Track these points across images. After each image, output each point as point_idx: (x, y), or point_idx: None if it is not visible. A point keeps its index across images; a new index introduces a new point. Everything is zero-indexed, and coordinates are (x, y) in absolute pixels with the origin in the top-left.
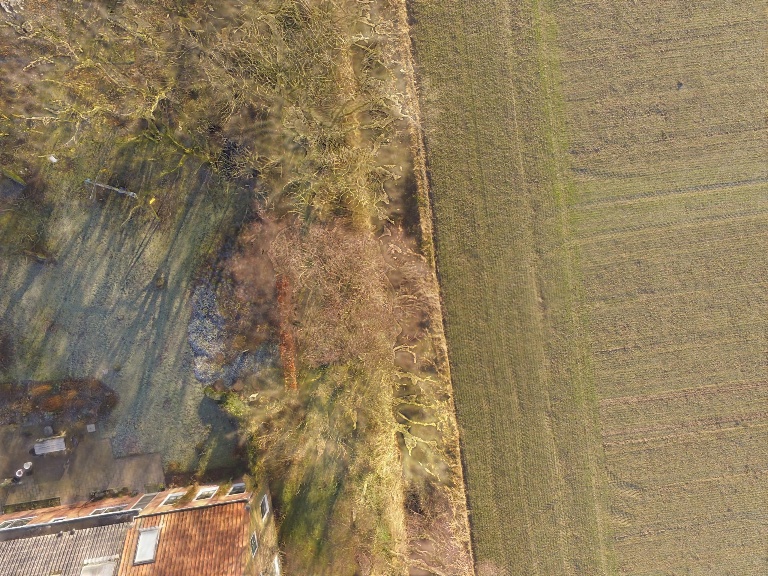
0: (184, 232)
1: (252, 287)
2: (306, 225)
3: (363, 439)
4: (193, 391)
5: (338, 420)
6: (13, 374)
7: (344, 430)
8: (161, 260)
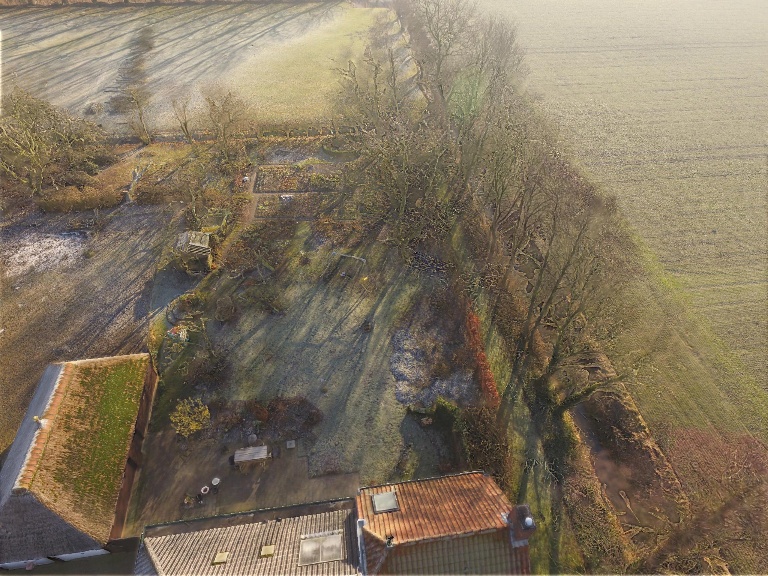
0: (387, 299)
1: (443, 333)
2: (479, 298)
3: (572, 466)
4: (394, 411)
5: (540, 445)
6: (226, 395)
7: (549, 455)
8: (369, 314)
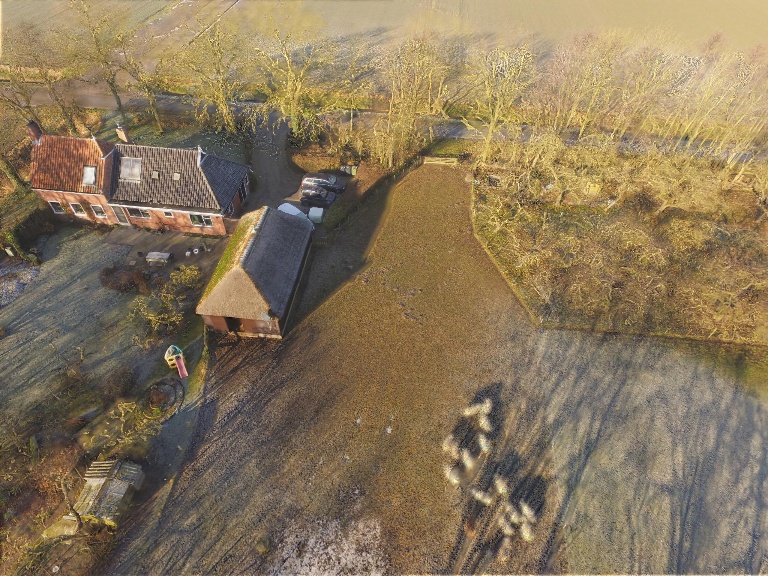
0: None
1: None
2: None
3: None
4: (49, 266)
5: None
6: None
7: None
8: None
